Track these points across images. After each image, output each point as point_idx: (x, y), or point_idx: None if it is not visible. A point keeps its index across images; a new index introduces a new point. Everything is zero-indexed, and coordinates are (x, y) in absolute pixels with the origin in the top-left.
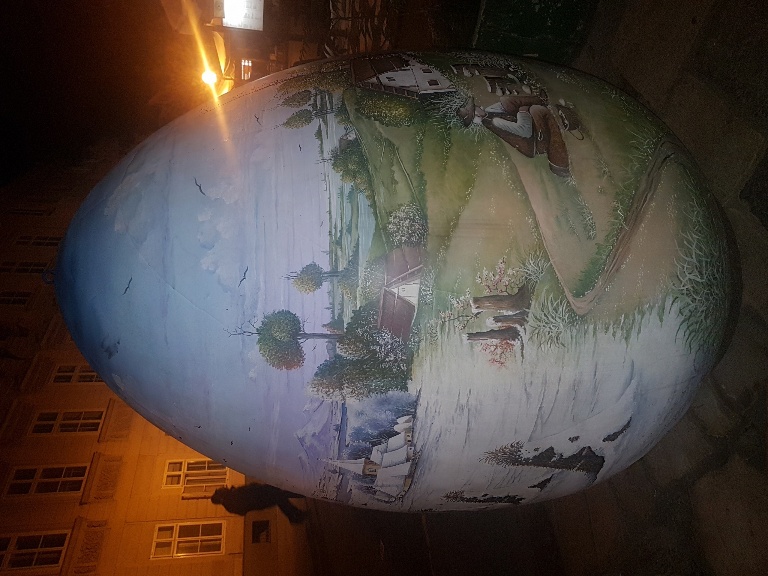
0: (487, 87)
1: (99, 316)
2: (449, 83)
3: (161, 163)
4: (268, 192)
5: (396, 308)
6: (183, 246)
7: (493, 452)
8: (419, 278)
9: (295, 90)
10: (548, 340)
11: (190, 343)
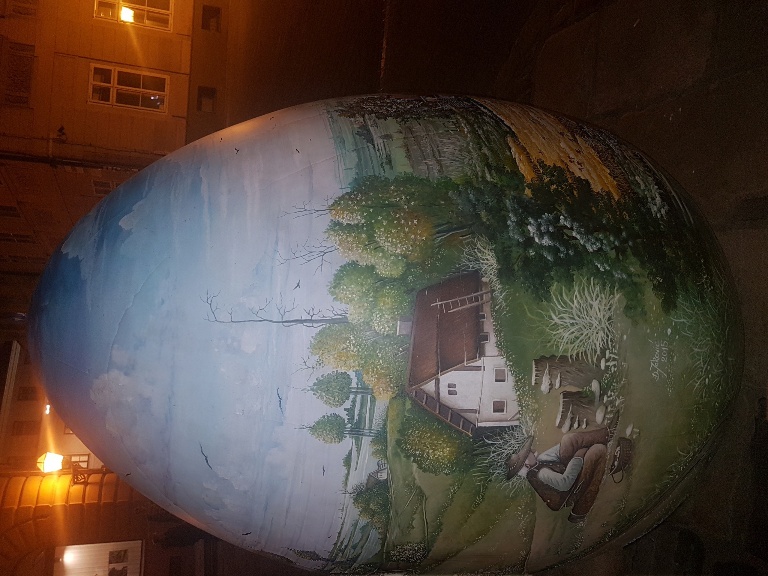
0: (557, 416)
1: None
2: (517, 409)
3: (158, 391)
4: (281, 498)
5: None
6: (186, 492)
7: None
8: (405, 573)
9: (333, 364)
10: None
11: None
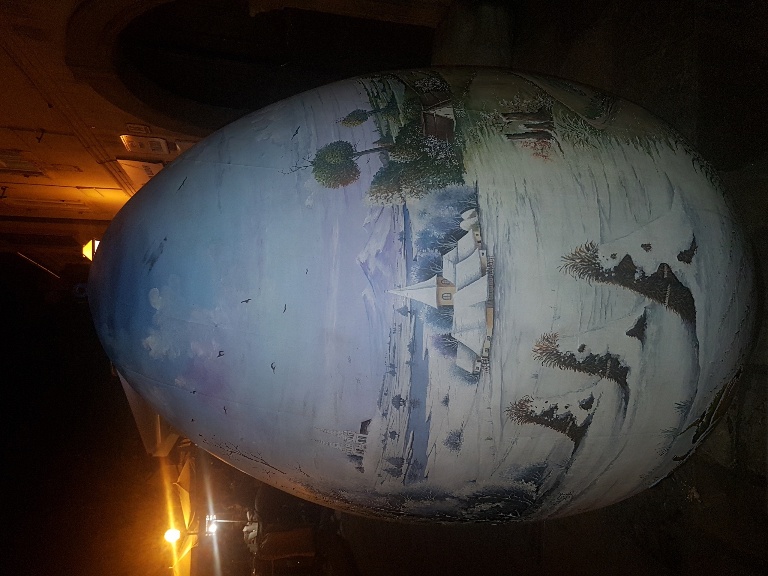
0: None
1: (146, 229)
2: None
3: None
4: (311, 96)
5: (437, 122)
6: (238, 138)
7: (570, 257)
8: (451, 105)
9: None
10: (579, 142)
11: (244, 198)
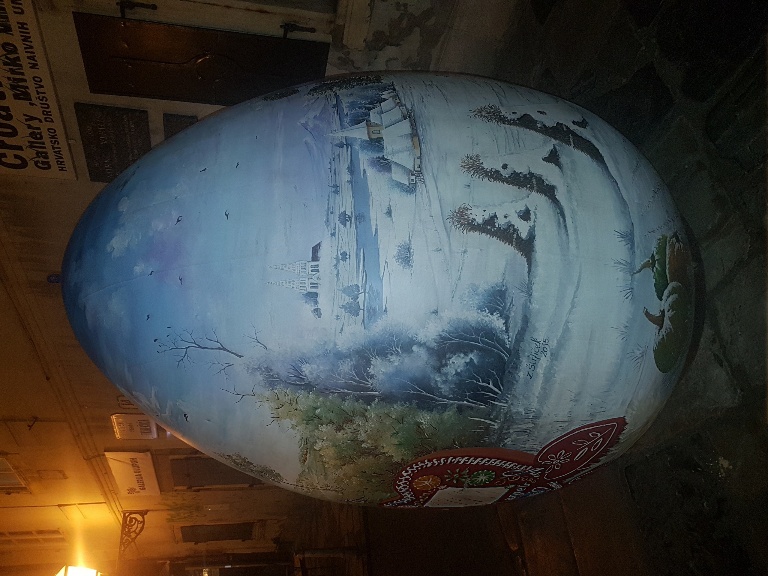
0: None
1: None
2: None
3: None
4: None
5: None
6: None
7: (477, 111)
8: None
9: None
10: None
11: None
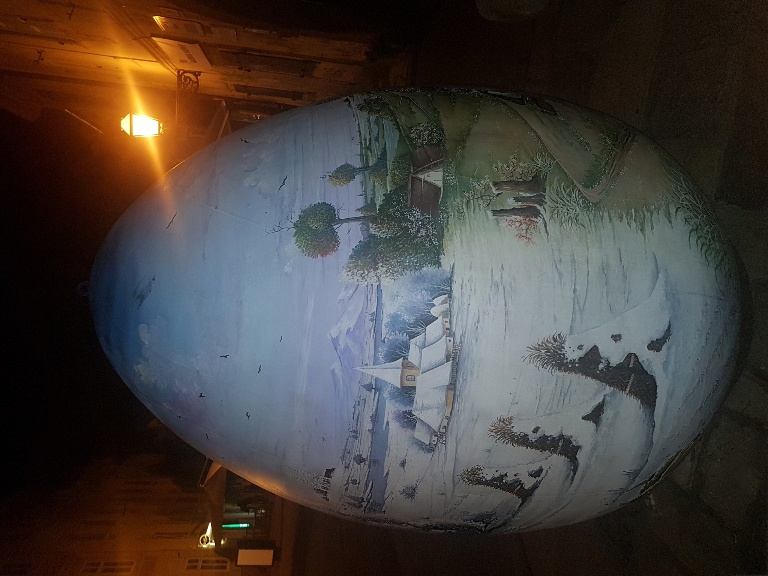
0: None
1: (137, 261)
2: None
3: None
4: (305, 130)
5: (423, 190)
6: (228, 176)
7: (536, 347)
8: (442, 167)
9: None
10: (568, 220)
11: (227, 252)
